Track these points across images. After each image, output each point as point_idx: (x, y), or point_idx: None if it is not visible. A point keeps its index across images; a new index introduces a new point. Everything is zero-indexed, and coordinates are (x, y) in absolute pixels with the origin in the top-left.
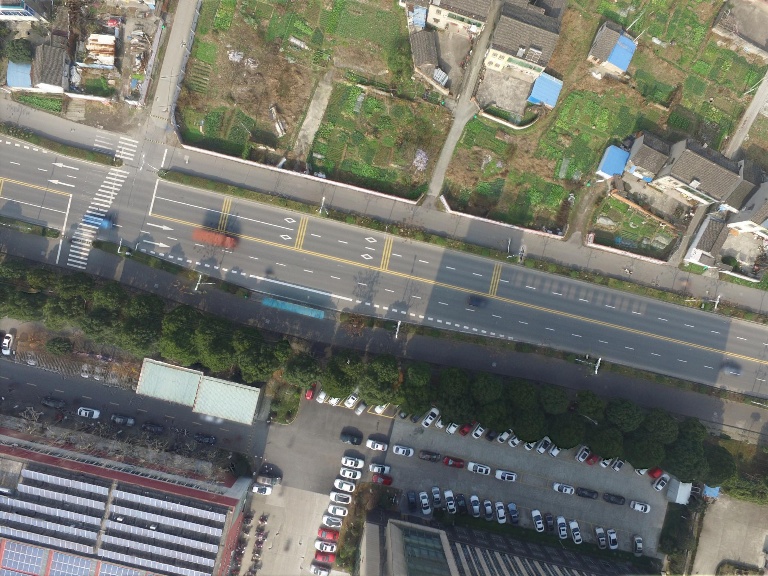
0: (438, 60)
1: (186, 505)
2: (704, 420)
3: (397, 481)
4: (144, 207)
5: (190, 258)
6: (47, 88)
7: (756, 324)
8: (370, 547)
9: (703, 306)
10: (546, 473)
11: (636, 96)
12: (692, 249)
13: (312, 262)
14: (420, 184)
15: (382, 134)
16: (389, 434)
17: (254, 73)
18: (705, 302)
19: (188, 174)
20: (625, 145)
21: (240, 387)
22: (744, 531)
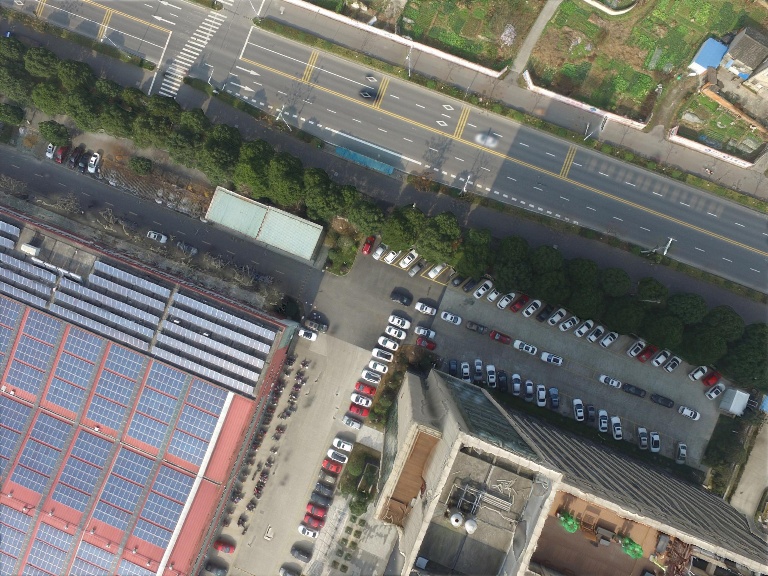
0: None
1: (240, 318)
2: None
3: (440, 348)
4: (236, 51)
5: (272, 104)
6: None
7: None
8: (412, 381)
9: None
10: (594, 364)
11: None
12: None
13: (387, 122)
14: (505, 59)
15: (474, 6)
16: (439, 300)
17: None
18: None
19: (282, 23)
20: (724, 41)
21: (304, 222)
22: None
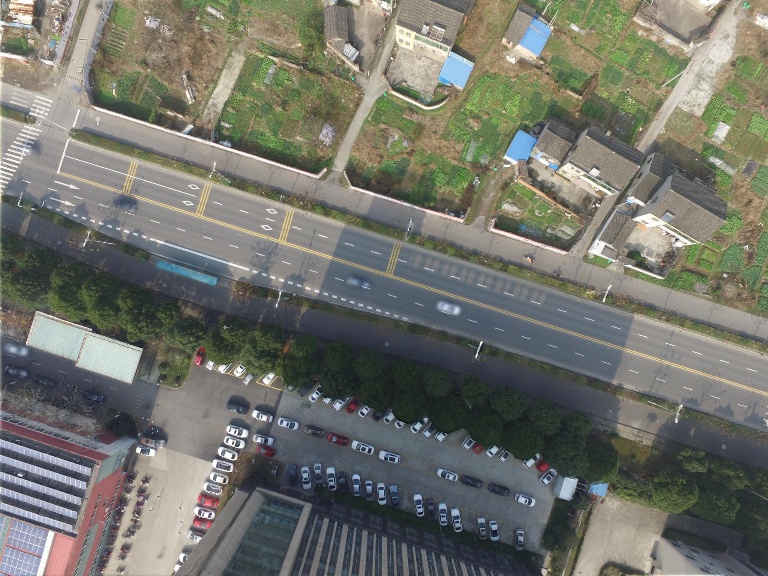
0: (349, 35)
1: (54, 455)
2: (598, 417)
3: (281, 454)
4: (53, 165)
5: (94, 218)
6: None
7: (659, 322)
8: (226, 511)
9: (604, 300)
10: (431, 458)
11: (549, 82)
12: (595, 240)
13: (212, 229)
14: (326, 159)
15: (291, 107)
16: (276, 406)
17: (169, 40)
18: (606, 296)
19: (97, 135)
20: (534, 131)
21: (123, 346)
22: (632, 534)
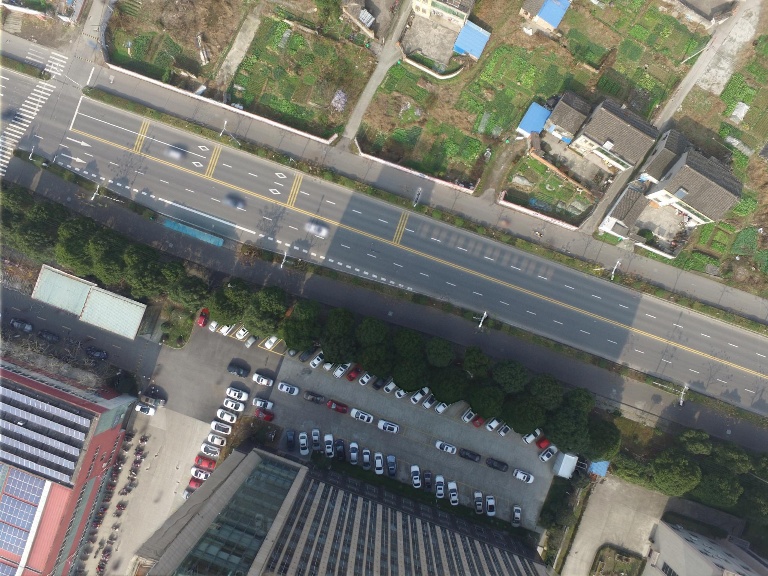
0: (365, 1)
1: (54, 405)
2: (601, 396)
3: (279, 419)
4: (66, 121)
5: (104, 175)
6: None
7: (668, 303)
8: (222, 468)
9: (612, 277)
10: (430, 430)
11: (566, 55)
12: (606, 217)
13: (220, 191)
14: (337, 125)
15: (304, 72)
16: (277, 371)
17: (186, 1)
18: (615, 274)
19: (110, 93)
20: (549, 104)
21: (127, 301)
22: (631, 516)
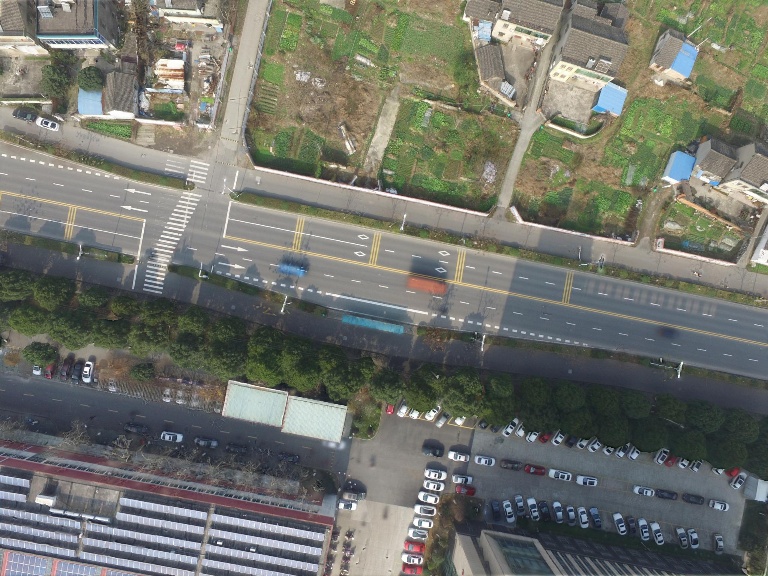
0: (504, 73)
1: (285, 526)
2: None
3: (480, 491)
4: (218, 229)
5: (266, 278)
6: (118, 115)
7: None
8: (471, 559)
9: None
10: (625, 476)
11: (698, 101)
12: (760, 250)
13: (387, 277)
14: (489, 196)
15: (450, 148)
16: (470, 445)
17: (321, 92)
18: None
19: (261, 195)
20: (690, 150)
21: (327, 405)
22: None
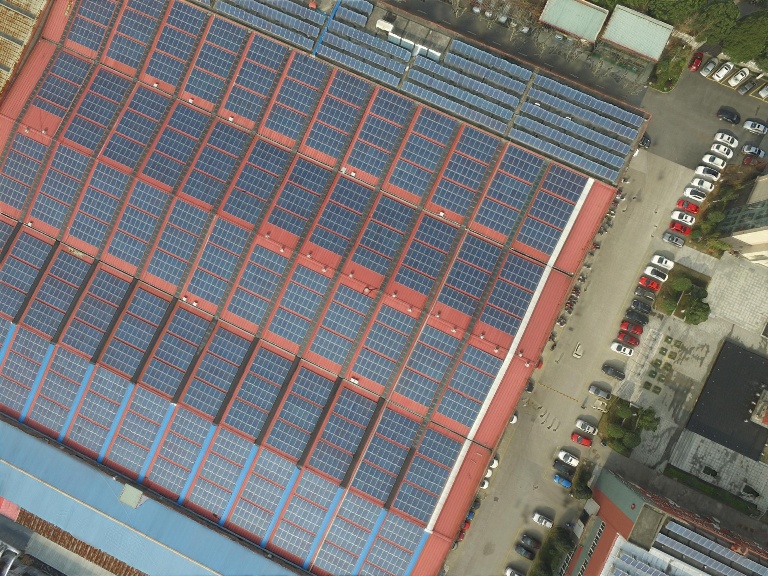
0: None
1: (605, 102)
2: None
3: (767, 170)
4: None
5: None
6: None
7: None
8: None
9: None
10: None
11: None
12: None
13: None
14: None
15: None
16: (767, 121)
17: None
18: None
19: None
20: None
21: (653, 22)
22: None
